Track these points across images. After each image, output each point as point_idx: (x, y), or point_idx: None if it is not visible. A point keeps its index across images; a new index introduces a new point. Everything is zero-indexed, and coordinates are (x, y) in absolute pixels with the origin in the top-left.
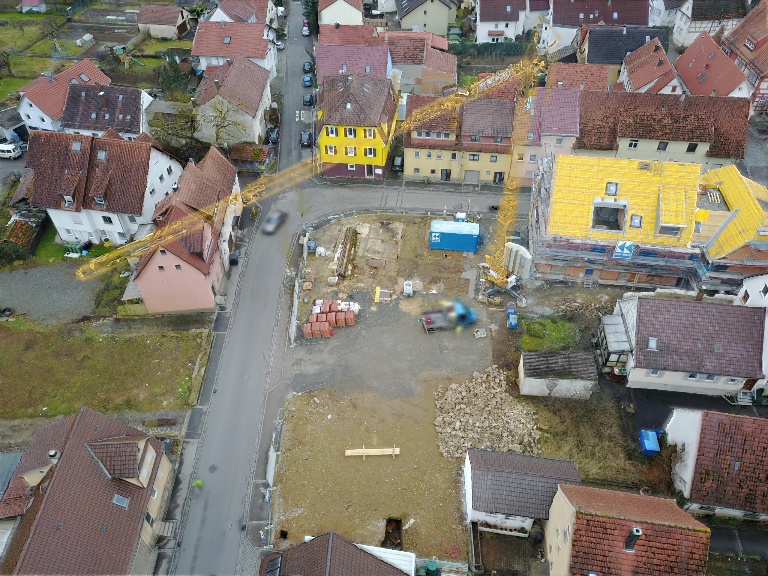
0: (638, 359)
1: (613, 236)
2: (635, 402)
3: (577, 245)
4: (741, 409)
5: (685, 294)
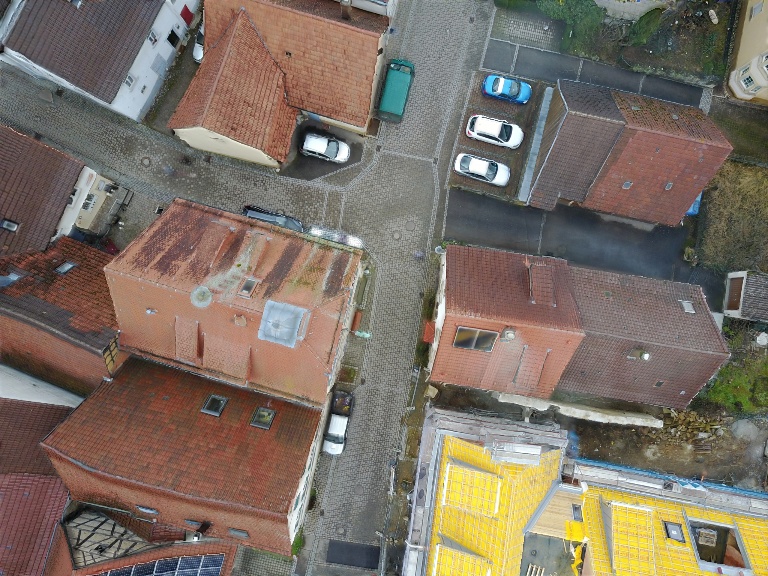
0: (699, 294)
1: (699, 514)
2: (673, 268)
3: (759, 497)
4: (554, 252)
5: (590, 412)
